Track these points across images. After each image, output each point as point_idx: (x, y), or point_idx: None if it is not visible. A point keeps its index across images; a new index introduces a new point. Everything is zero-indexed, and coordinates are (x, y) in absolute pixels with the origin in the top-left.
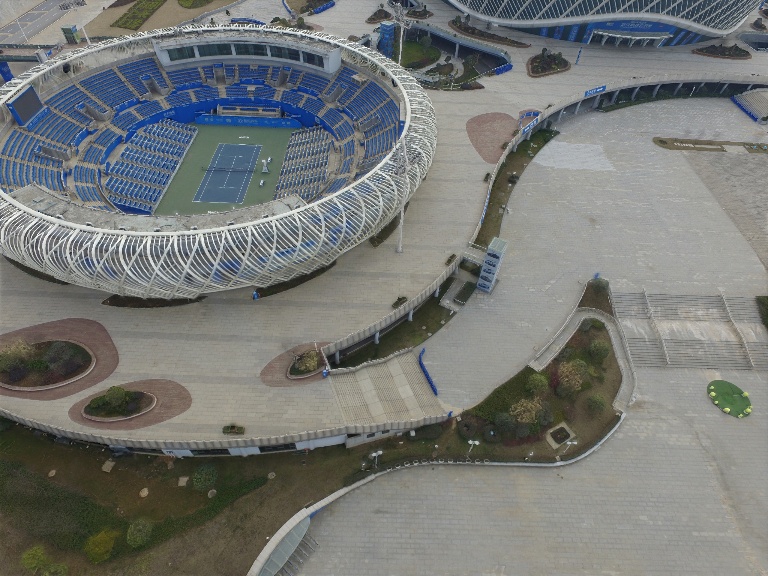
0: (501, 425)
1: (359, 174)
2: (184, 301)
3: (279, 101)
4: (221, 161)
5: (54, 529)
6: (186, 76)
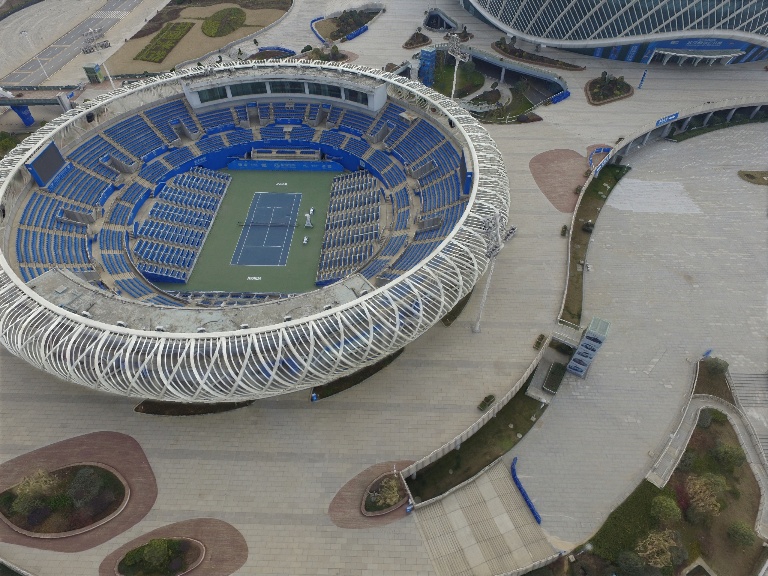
0: (629, 571)
1: (419, 233)
2: (231, 405)
3: (319, 143)
4: (258, 214)
5: None
6: (217, 118)
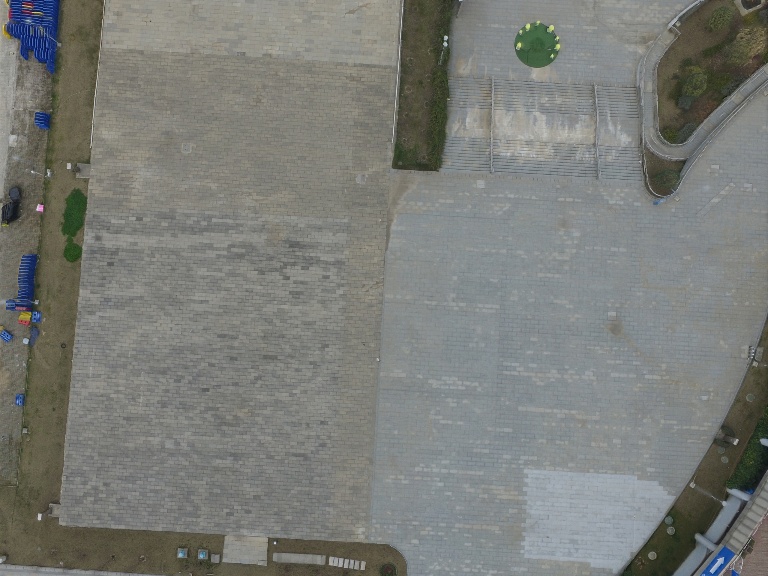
0: None
1: None
2: None
3: None
4: None
5: None
6: None
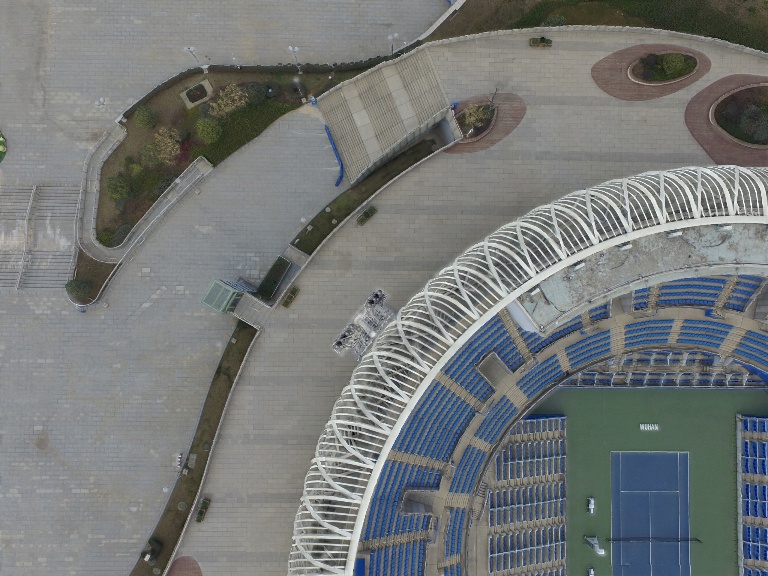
0: (260, 85)
1: (434, 487)
2: None
3: None
4: (674, 568)
5: None
6: None
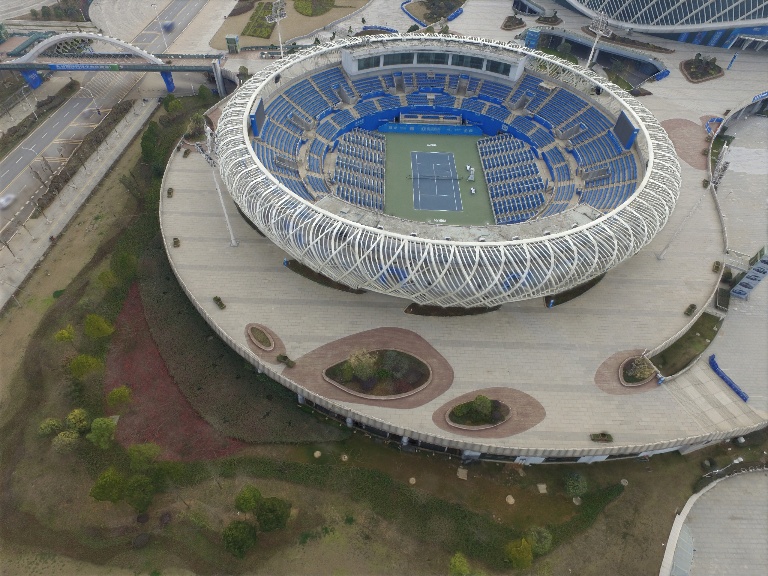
0: None
1: (588, 182)
2: (483, 309)
3: (461, 109)
4: (422, 169)
5: (444, 536)
6: (369, 85)
